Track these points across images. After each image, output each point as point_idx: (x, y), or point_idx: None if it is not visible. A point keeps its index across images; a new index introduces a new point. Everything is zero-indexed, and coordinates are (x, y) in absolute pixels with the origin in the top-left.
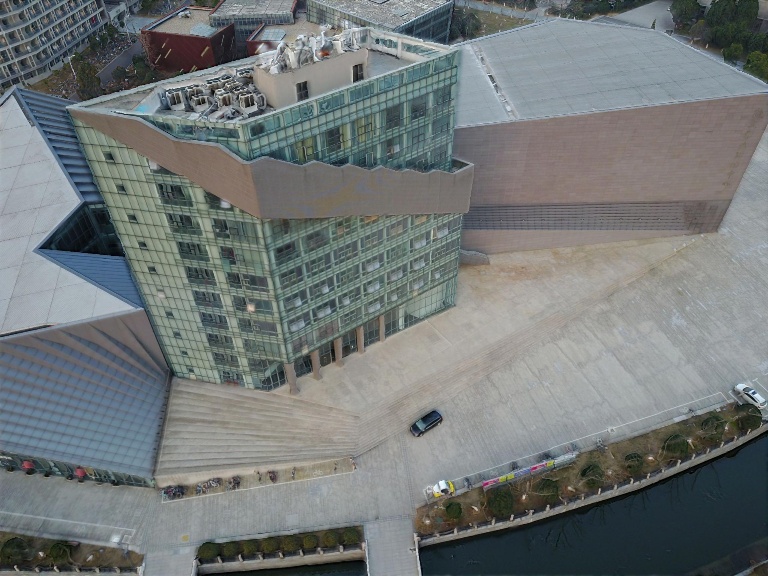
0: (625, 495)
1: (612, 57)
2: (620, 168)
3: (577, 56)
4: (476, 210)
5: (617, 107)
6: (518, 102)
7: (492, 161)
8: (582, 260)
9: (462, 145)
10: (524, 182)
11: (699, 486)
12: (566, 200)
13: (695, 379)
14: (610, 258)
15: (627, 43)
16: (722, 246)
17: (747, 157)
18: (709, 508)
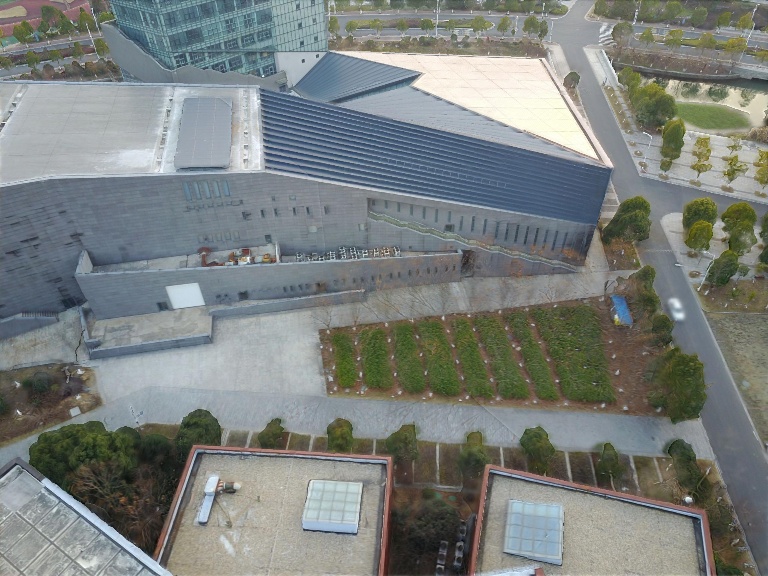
0: None
1: None
2: None
3: None
4: None
5: None
6: (4, 98)
7: None
8: None
9: None
10: None
11: None
12: None
13: None
14: None
15: None
16: None
17: None
18: None
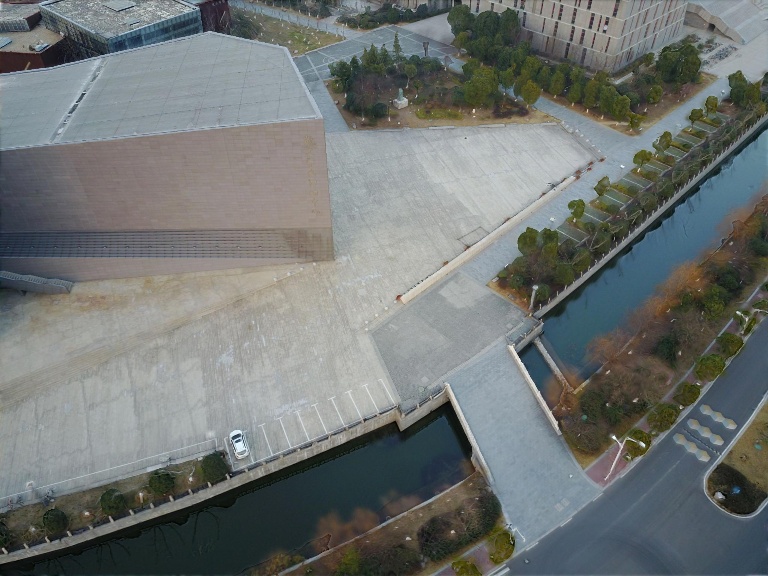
0: (51, 553)
1: (213, 76)
2: (191, 194)
3: (183, 74)
4: (54, 236)
5: (157, 131)
6: (74, 124)
7: (46, 186)
8: (170, 289)
9: (3, 169)
10: (94, 208)
11: (199, 537)
12: (151, 226)
13: (199, 423)
14: (201, 288)
15: (243, 61)
16: (328, 276)
17: (323, 184)
18: (183, 563)
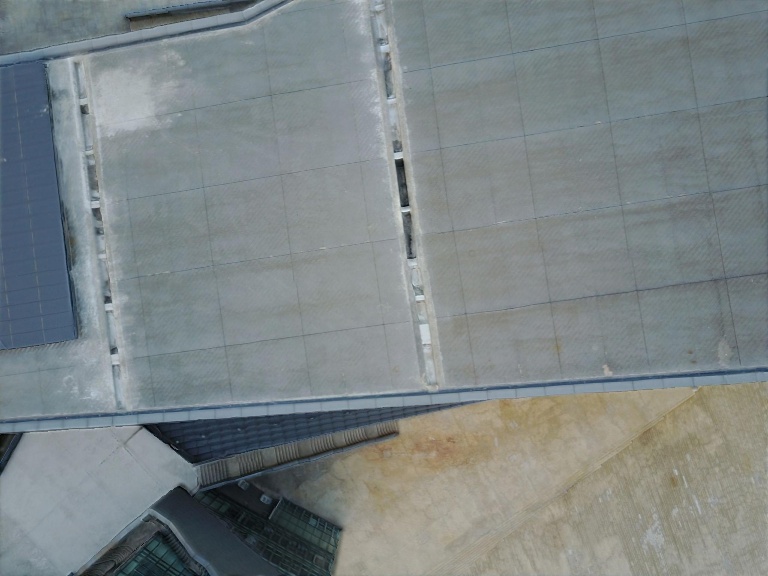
0: None
1: (705, 109)
2: None
3: (621, 89)
4: None
5: (657, 371)
6: (448, 313)
7: None
8: (543, 418)
9: None
10: None
11: None
12: None
13: None
14: (588, 412)
15: (763, 27)
16: None
17: None
18: None
